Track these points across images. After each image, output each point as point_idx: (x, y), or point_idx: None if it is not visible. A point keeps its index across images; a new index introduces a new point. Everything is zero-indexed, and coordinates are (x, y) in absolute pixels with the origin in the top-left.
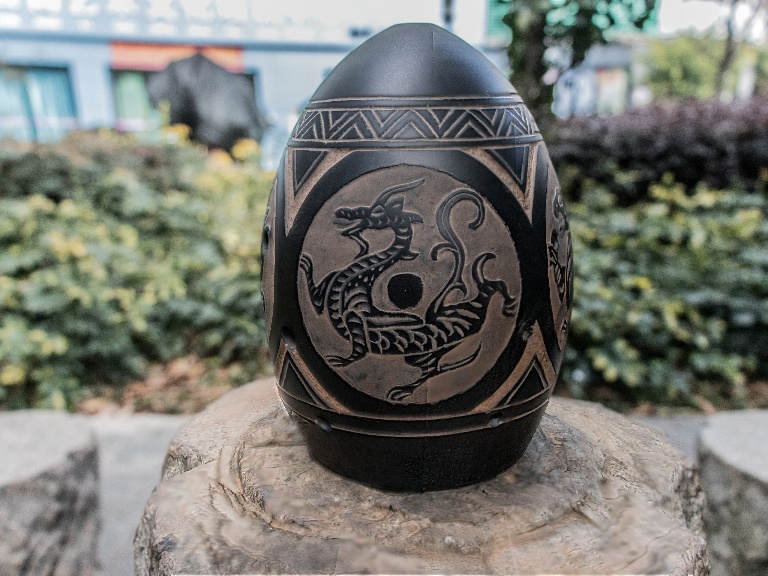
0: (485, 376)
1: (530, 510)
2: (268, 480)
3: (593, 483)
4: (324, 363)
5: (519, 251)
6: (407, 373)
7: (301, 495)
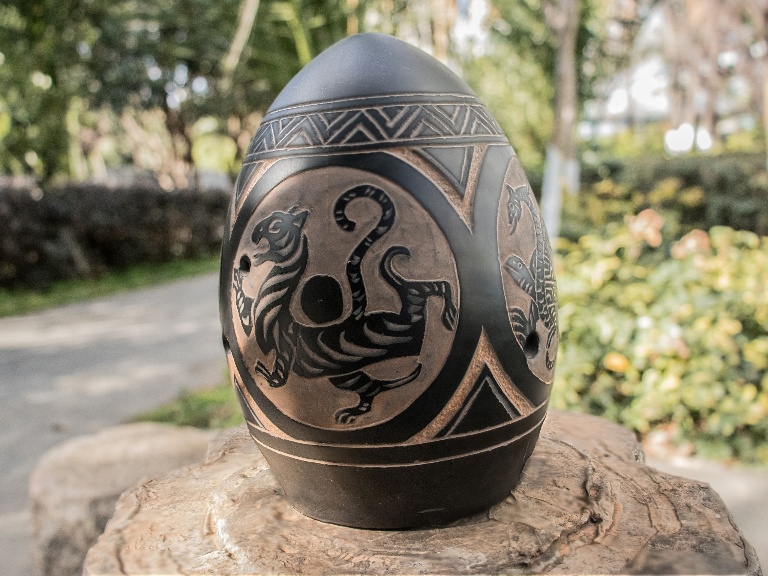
0: None
1: None
2: None
3: (253, 568)
4: None
5: None
6: None
7: None
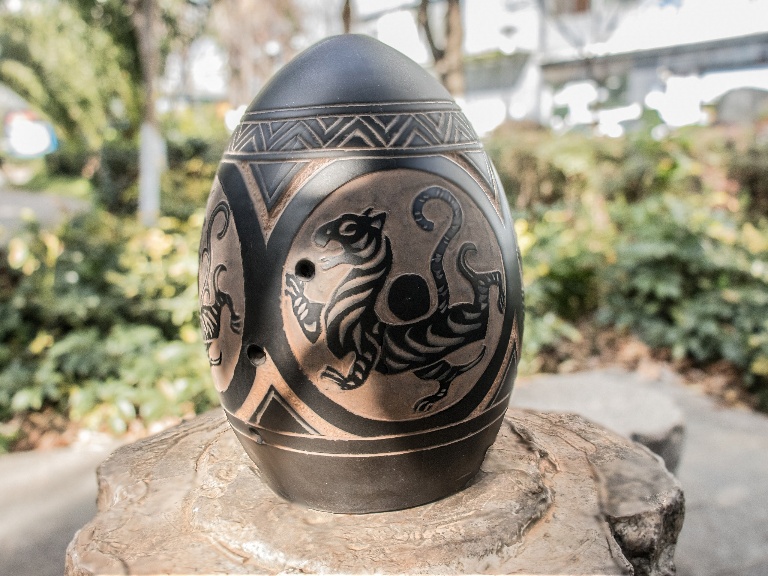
0: (231, 384)
1: (252, 538)
2: None
3: (342, 574)
4: None
5: (246, 270)
6: None
7: None
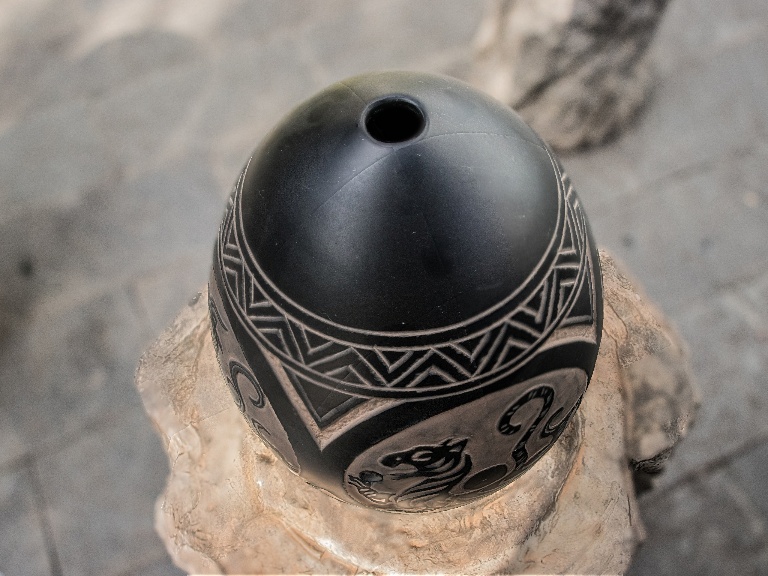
0: None
1: (323, 535)
2: None
3: None
4: None
5: (298, 453)
6: None
7: None
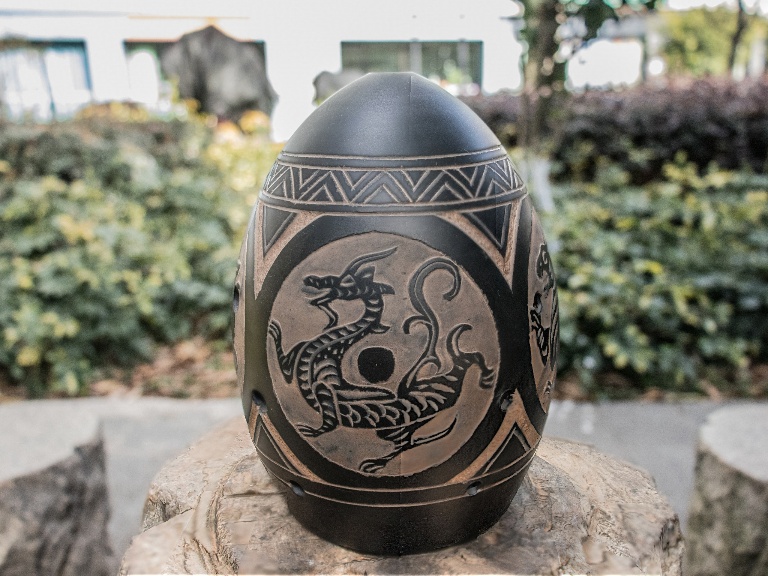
0: (461, 448)
1: None
2: (243, 538)
3: (577, 545)
4: (295, 432)
5: (497, 320)
6: (379, 446)
7: (275, 557)
